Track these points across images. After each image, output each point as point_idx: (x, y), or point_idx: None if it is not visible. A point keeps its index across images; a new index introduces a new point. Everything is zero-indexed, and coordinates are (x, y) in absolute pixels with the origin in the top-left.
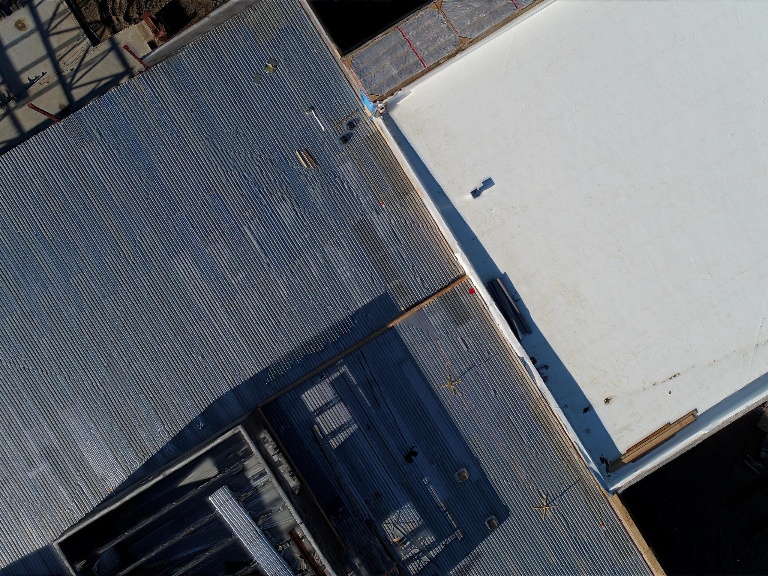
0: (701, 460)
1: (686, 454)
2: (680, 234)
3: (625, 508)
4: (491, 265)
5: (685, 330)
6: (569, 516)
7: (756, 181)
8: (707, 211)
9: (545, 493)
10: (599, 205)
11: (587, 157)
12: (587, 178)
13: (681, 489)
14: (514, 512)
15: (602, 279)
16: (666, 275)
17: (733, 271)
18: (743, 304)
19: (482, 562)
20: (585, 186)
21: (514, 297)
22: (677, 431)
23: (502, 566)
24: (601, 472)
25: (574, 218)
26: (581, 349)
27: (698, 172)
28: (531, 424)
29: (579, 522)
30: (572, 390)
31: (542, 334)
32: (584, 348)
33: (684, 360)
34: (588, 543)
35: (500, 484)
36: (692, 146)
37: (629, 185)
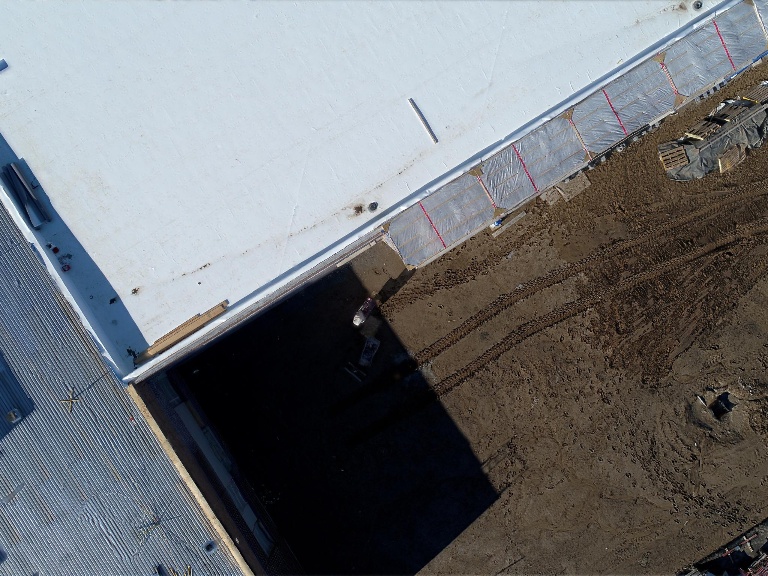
0: (303, 368)
1: (287, 362)
2: (206, 119)
3: (141, 399)
4: (7, 150)
5: (214, 219)
6: (97, 410)
7: (284, 64)
8: (233, 95)
9: (71, 386)
10: (119, 88)
11: (104, 38)
12: (105, 60)
13: (282, 397)
14: (39, 405)
15: (125, 165)
16: (192, 161)
17: (263, 158)
18: (274, 192)
19: (6, 456)
20: (104, 68)
21: (33, 183)
22: (205, 322)
23: (27, 460)
24: (128, 364)
25: (93, 102)
26: (105, 238)
27: (222, 54)
28: (57, 315)
29: (107, 416)
30: (97, 280)
31: (64, 222)
32: (108, 237)
33: (214, 250)
34: (117, 437)
35: (24, 376)
36: (215, 27)
37: (150, 68)
